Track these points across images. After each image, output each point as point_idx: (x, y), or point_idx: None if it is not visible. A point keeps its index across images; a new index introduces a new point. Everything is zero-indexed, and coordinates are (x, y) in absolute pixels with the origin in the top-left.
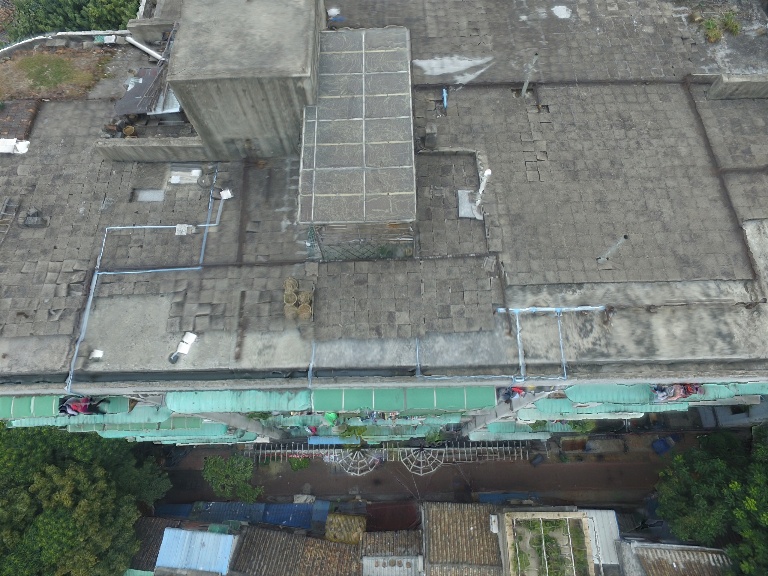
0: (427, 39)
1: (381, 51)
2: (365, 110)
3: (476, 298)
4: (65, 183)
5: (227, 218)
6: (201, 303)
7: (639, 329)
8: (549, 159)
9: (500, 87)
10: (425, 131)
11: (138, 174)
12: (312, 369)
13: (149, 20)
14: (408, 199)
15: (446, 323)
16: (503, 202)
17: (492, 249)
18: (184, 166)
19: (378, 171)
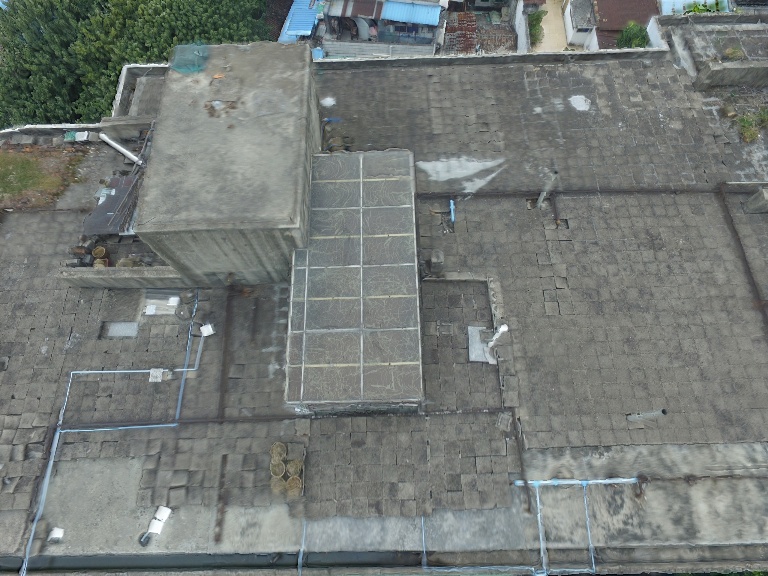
0: (432, 136)
1: (381, 180)
2: (363, 255)
3: (490, 465)
4: (27, 315)
5: (208, 360)
6: (176, 470)
7: (677, 504)
8: (570, 287)
9: (513, 196)
10: (431, 259)
11: (109, 304)
12: (302, 557)
13: (124, 118)
14: (413, 371)
15: (456, 498)
16: (519, 341)
17: (507, 404)
18: (161, 293)
19: (378, 334)
